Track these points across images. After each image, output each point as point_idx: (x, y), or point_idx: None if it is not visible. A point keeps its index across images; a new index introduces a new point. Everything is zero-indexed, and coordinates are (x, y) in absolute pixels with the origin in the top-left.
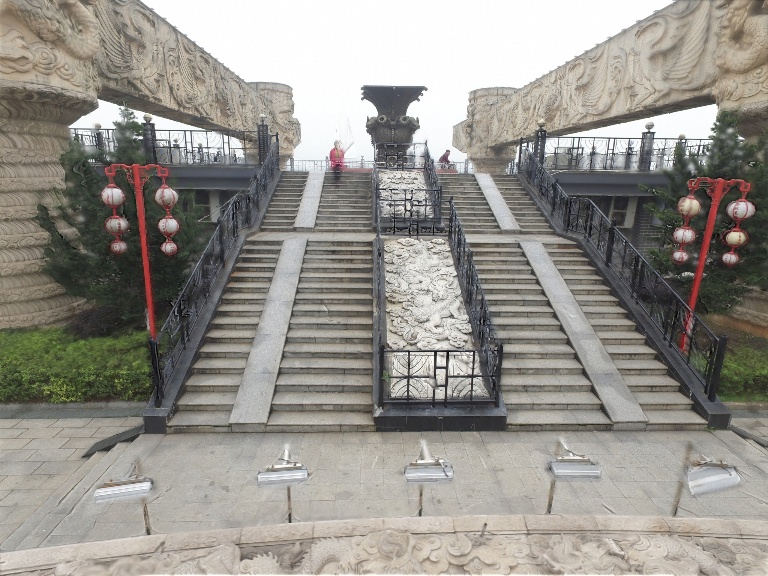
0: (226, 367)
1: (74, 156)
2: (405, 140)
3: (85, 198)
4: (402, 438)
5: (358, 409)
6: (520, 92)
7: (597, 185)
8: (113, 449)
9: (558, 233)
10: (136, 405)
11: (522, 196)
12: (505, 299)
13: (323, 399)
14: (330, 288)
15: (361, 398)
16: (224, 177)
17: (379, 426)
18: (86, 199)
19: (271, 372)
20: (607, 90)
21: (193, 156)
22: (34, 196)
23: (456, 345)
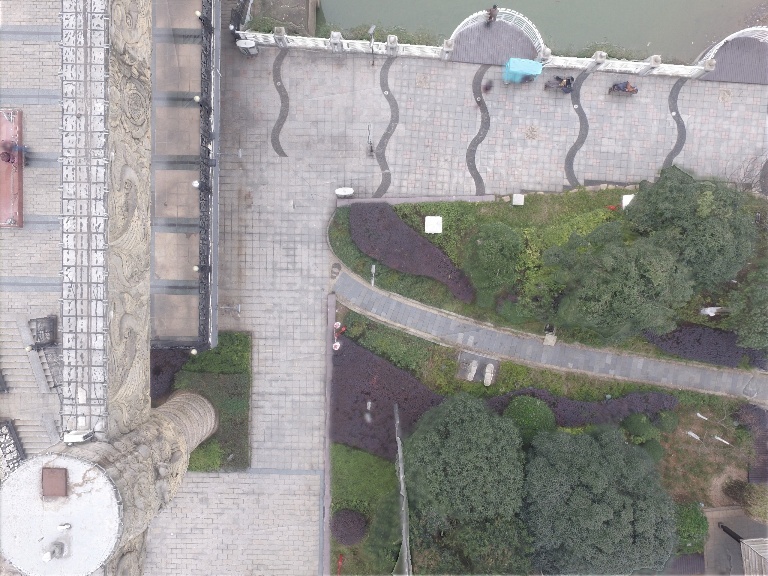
0: None
1: None
2: None
3: None
4: None
5: None
6: None
7: None
8: None
9: None
10: None
11: None
12: None
13: None
14: None
15: None
16: None
17: None
18: None
19: None
20: None
21: None
22: None
23: None
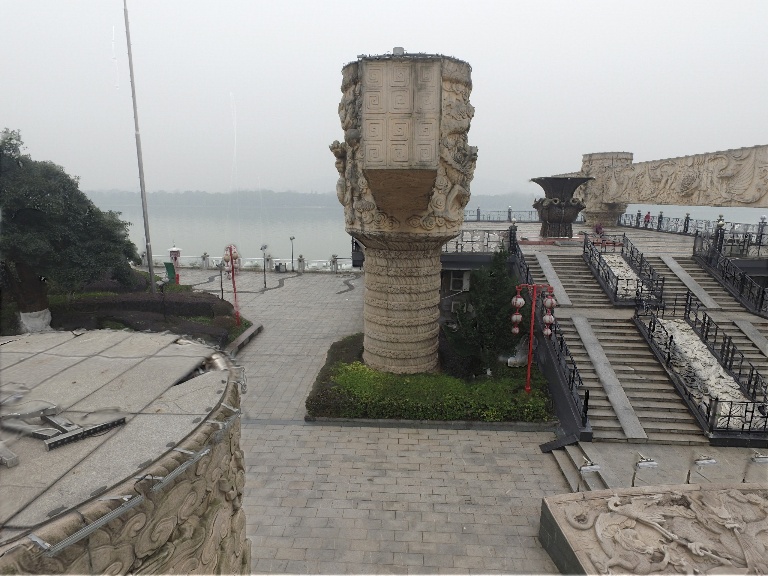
0: (599, 405)
1: (483, 275)
2: (572, 217)
3: (487, 299)
4: (729, 450)
5: (692, 433)
6: (647, 165)
7: (763, 269)
8: (568, 449)
9: (752, 312)
10: (532, 425)
11: (706, 277)
12: (746, 365)
13: (669, 426)
14: (625, 354)
15: (691, 427)
16: (483, 261)
17: (712, 443)
18: (487, 300)
19: (630, 409)
20: (755, 186)
21: (462, 247)
22: (434, 292)
23: (735, 396)
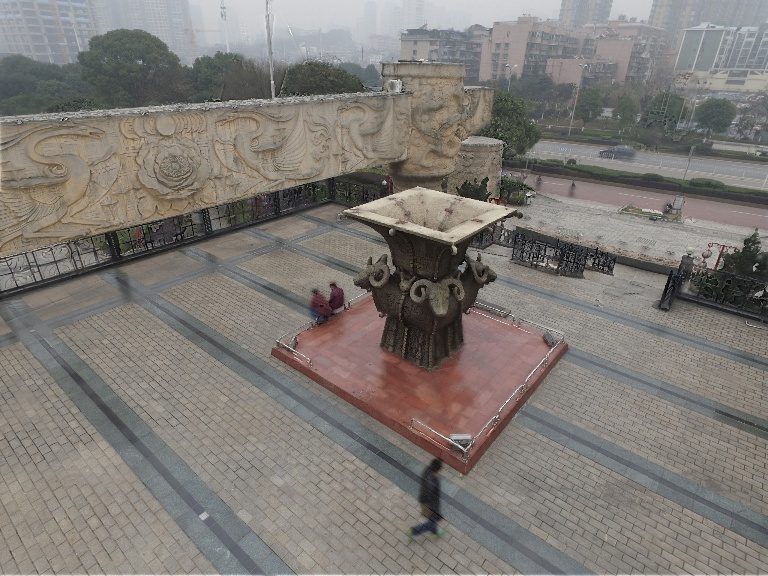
0: None
1: None
2: None
3: None
4: None
5: None
6: None
7: None
8: None
9: None
10: None
11: None
12: None
13: None
14: None
15: None
16: None
17: None
18: None
19: None
20: (312, 155)
21: None
22: None
23: None
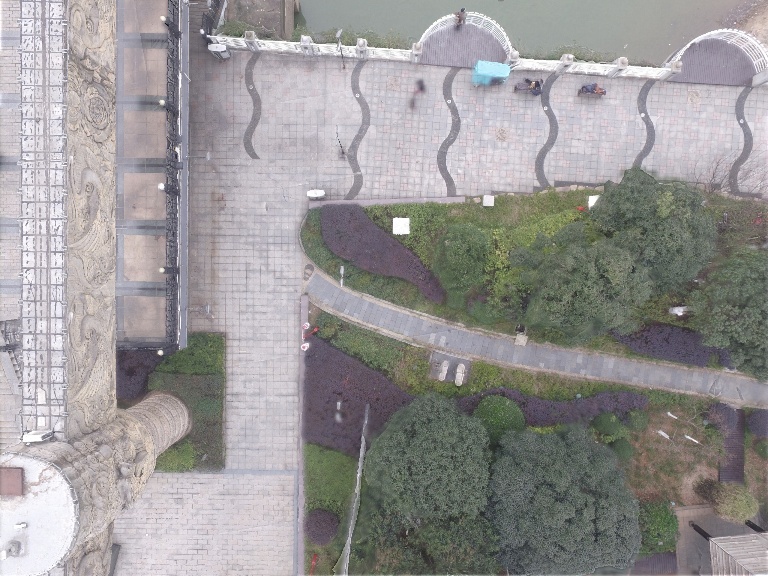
0: None
1: None
2: None
3: None
4: None
5: None
6: None
7: None
8: None
9: None
10: None
11: None
12: None
13: None
14: None
15: None
16: None
17: None
18: None
19: None
20: None
21: None
22: None
23: None
